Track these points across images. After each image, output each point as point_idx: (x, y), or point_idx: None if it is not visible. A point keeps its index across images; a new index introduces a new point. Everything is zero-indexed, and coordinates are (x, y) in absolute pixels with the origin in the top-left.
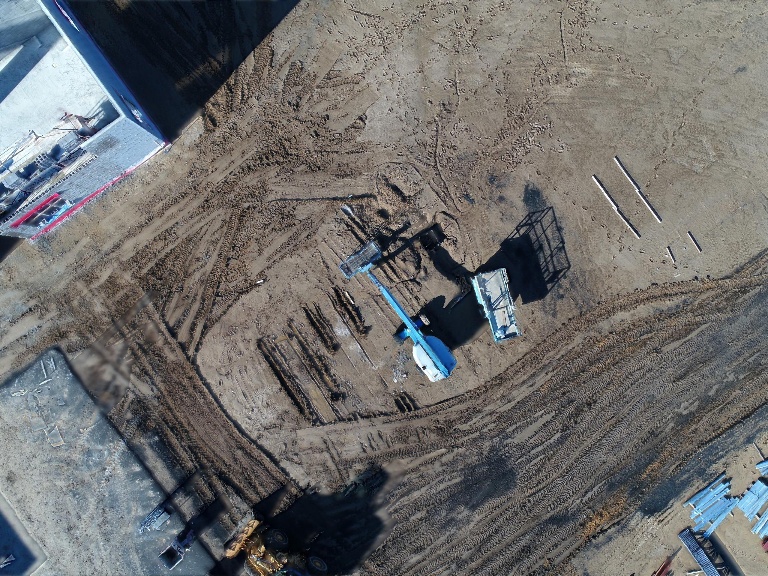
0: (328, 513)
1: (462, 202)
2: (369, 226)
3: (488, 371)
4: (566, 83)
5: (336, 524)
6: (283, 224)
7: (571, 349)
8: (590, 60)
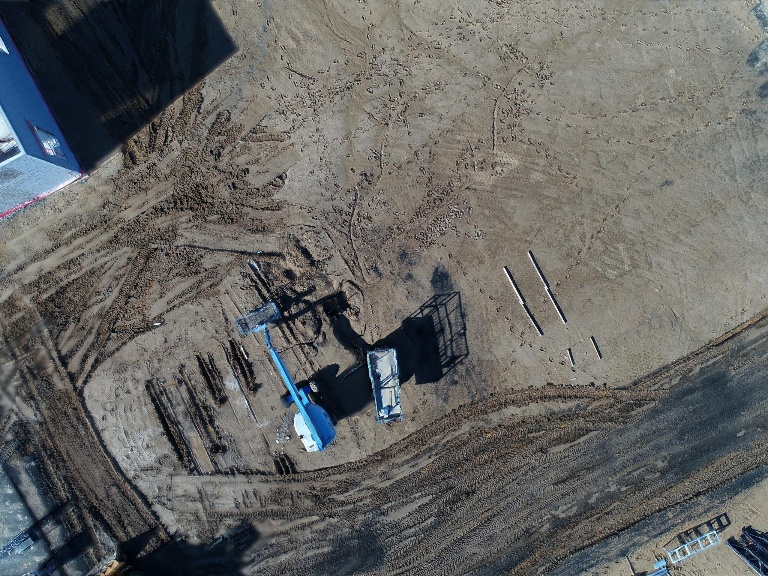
0: (191, 562)
1: (370, 274)
2: (274, 285)
3: (371, 445)
4: (491, 171)
5: (198, 574)
6: (188, 270)
7: (457, 436)
8: (518, 151)
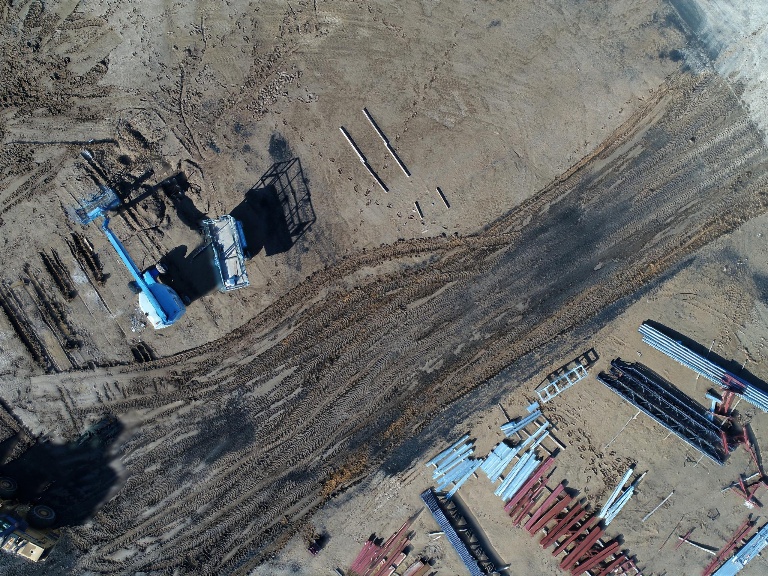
0: (61, 462)
1: (207, 150)
2: (110, 172)
3: (229, 323)
4: (316, 32)
5: (69, 474)
6: (20, 167)
7: (315, 303)
8: (341, 9)
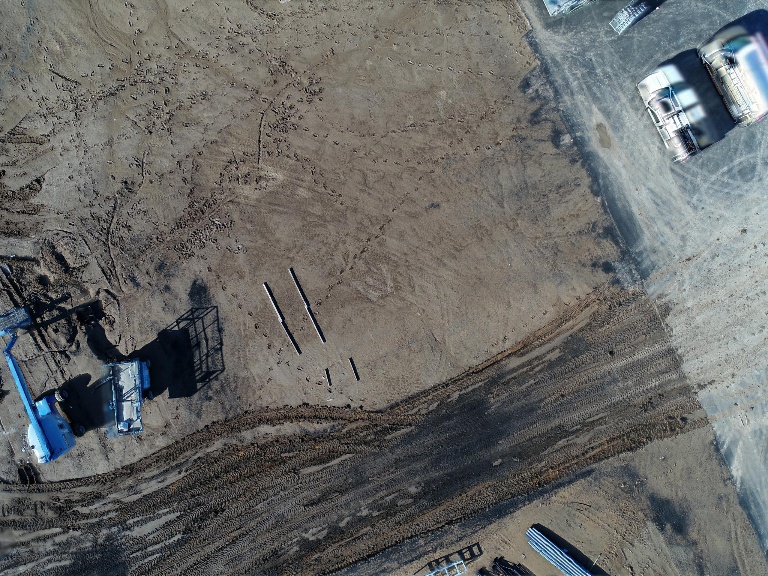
0: None
1: (127, 284)
2: (27, 290)
3: (120, 458)
4: (255, 185)
5: None
6: None
7: (209, 452)
8: (284, 167)
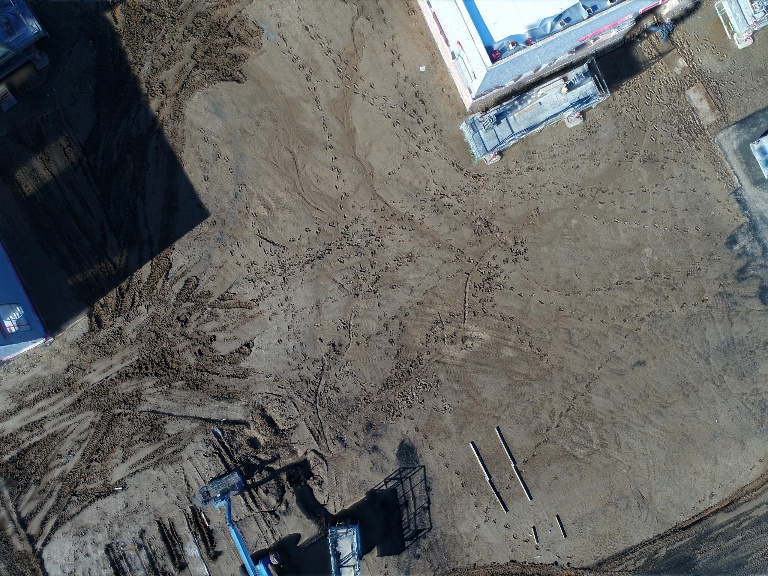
0: None
1: (335, 444)
2: (237, 452)
3: None
4: (461, 345)
5: None
6: (151, 436)
7: None
8: (489, 326)
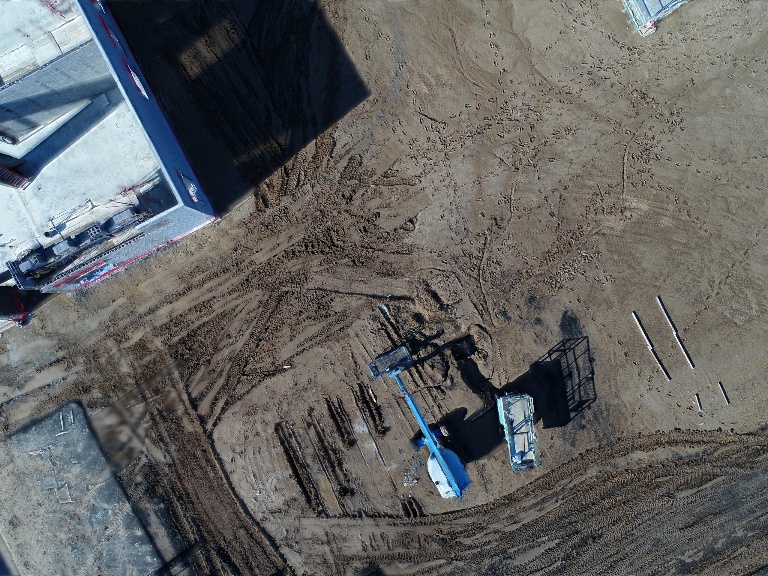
0: None
1: (499, 318)
2: (403, 328)
3: (498, 489)
4: (620, 216)
5: None
6: (318, 314)
7: (584, 480)
8: (648, 197)
